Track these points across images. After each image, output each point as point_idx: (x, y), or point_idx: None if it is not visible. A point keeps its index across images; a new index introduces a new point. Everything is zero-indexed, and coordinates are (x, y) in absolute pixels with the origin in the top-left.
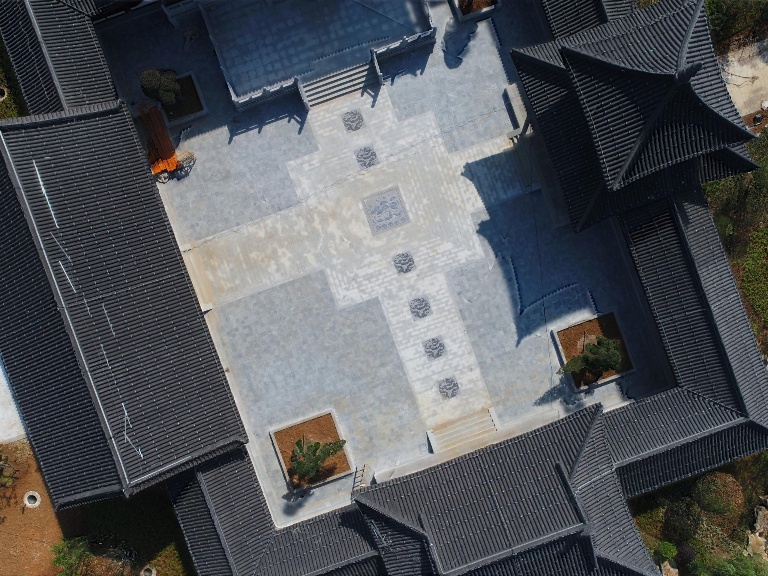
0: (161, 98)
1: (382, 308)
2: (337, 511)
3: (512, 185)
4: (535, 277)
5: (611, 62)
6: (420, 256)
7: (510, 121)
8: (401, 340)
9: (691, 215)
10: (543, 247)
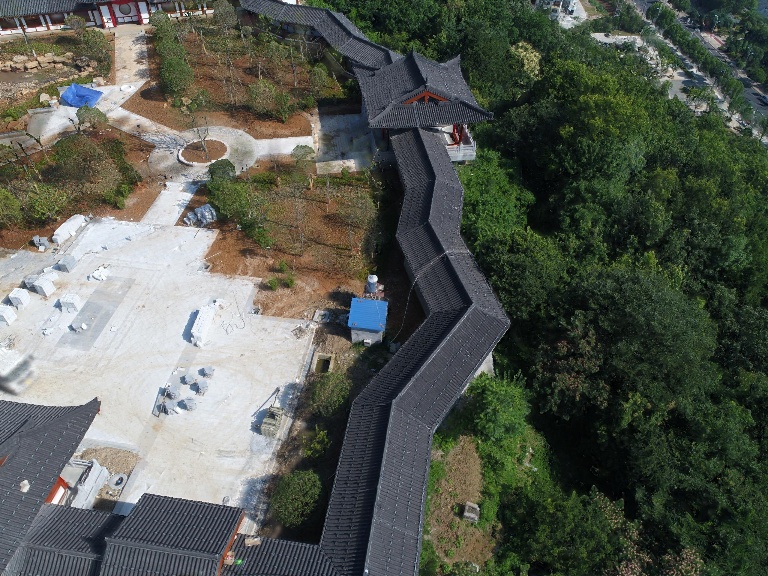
0: None
1: None
2: None
3: None
4: None
5: None
6: None
7: None
8: None
9: (72, 2)
10: None
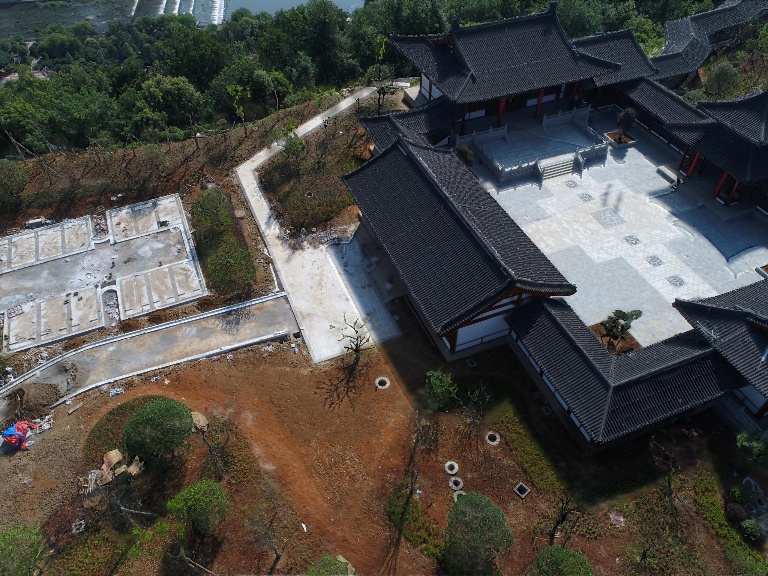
0: (467, 158)
1: (627, 262)
2: (659, 342)
3: (684, 205)
4: (726, 244)
5: (729, 101)
6: (641, 237)
7: (667, 181)
8: (649, 278)
9: None
10: (722, 230)
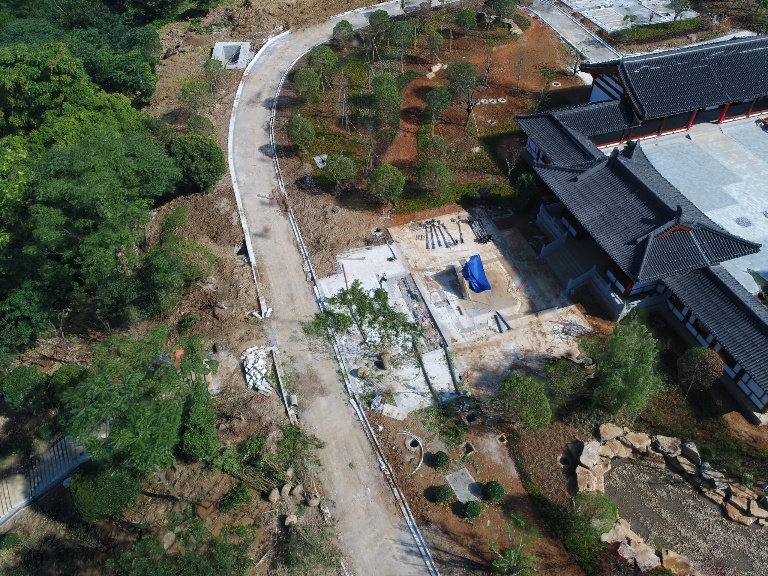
0: None
1: (733, 205)
2: None
3: None
4: None
5: None
6: None
7: None
8: (715, 213)
9: None
10: None
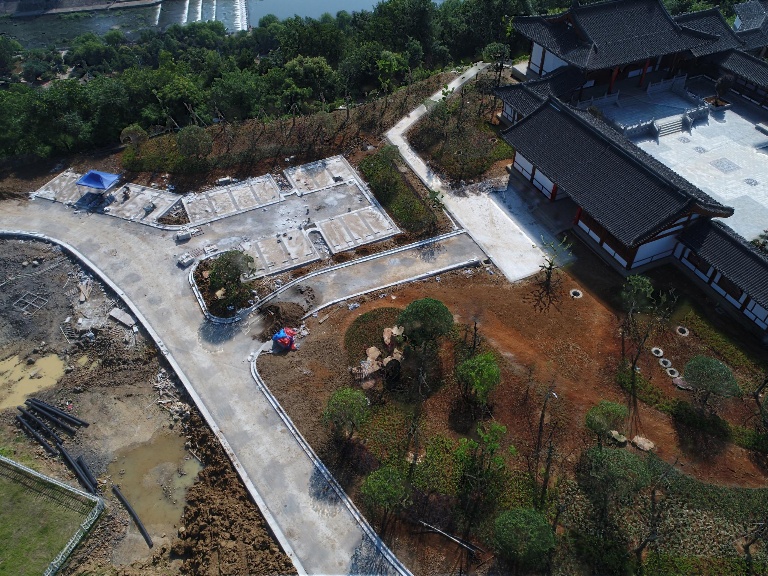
0: None
1: (752, 199)
2: None
3: None
4: None
5: None
6: (758, 179)
7: (767, 136)
8: None
9: None
10: None
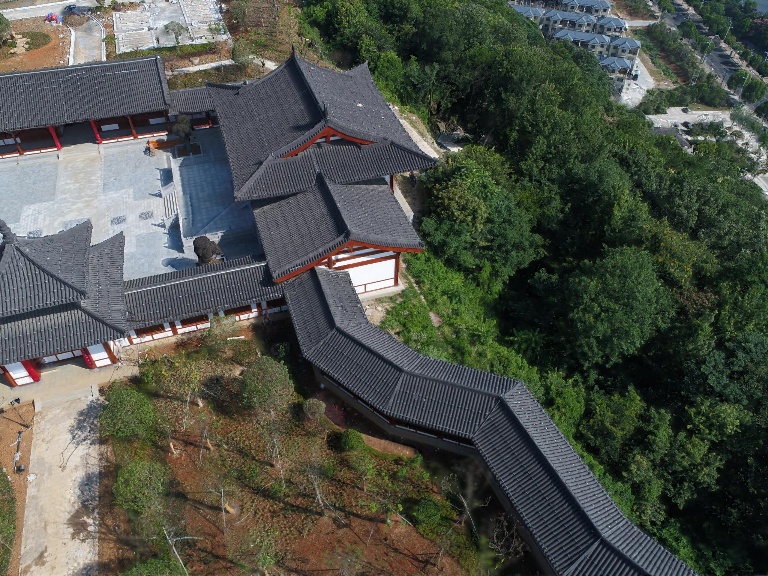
0: None
1: (10, 224)
2: None
3: None
4: None
5: None
6: None
7: None
8: None
9: None
10: None
